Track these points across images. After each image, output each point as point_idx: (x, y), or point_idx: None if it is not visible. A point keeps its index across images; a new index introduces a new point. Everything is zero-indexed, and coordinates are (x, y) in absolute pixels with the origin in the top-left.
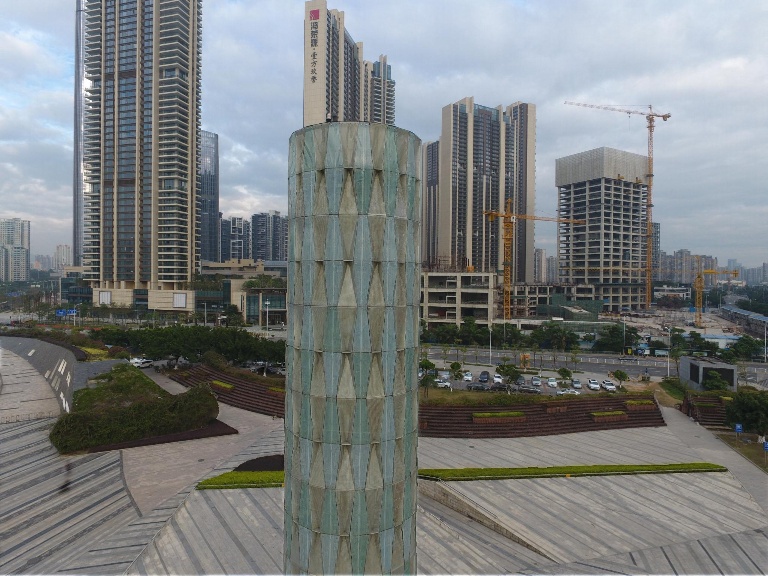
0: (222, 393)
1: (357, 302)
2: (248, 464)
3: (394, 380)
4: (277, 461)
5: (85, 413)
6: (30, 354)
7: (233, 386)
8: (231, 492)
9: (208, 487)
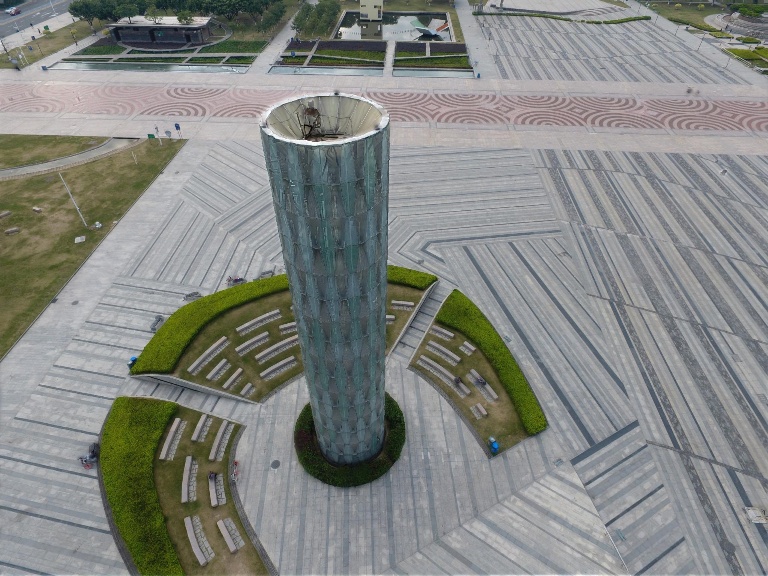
0: None
1: None
2: None
3: None
4: None
5: None
6: None
7: None
8: None
9: None
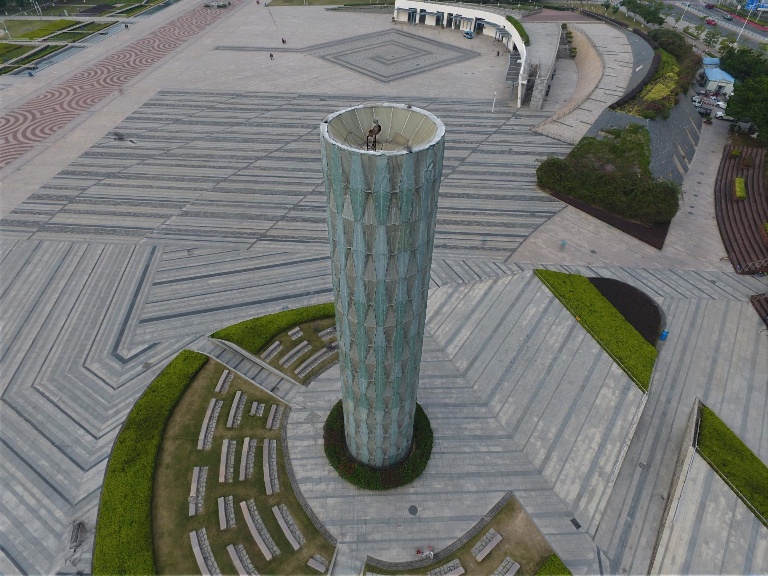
0: (728, 197)
1: (332, 254)
2: (607, 282)
3: (349, 311)
4: (631, 298)
5: (563, 163)
6: (637, 69)
7: (744, 196)
8: (545, 291)
9: (539, 276)
